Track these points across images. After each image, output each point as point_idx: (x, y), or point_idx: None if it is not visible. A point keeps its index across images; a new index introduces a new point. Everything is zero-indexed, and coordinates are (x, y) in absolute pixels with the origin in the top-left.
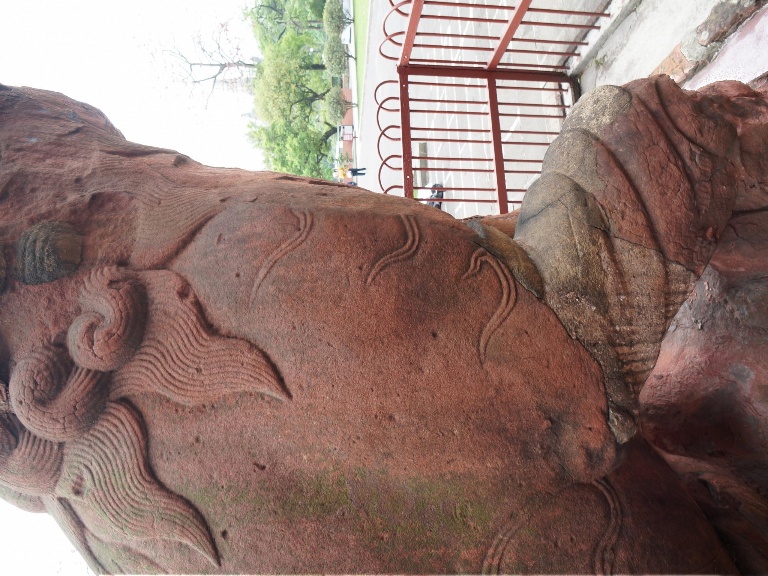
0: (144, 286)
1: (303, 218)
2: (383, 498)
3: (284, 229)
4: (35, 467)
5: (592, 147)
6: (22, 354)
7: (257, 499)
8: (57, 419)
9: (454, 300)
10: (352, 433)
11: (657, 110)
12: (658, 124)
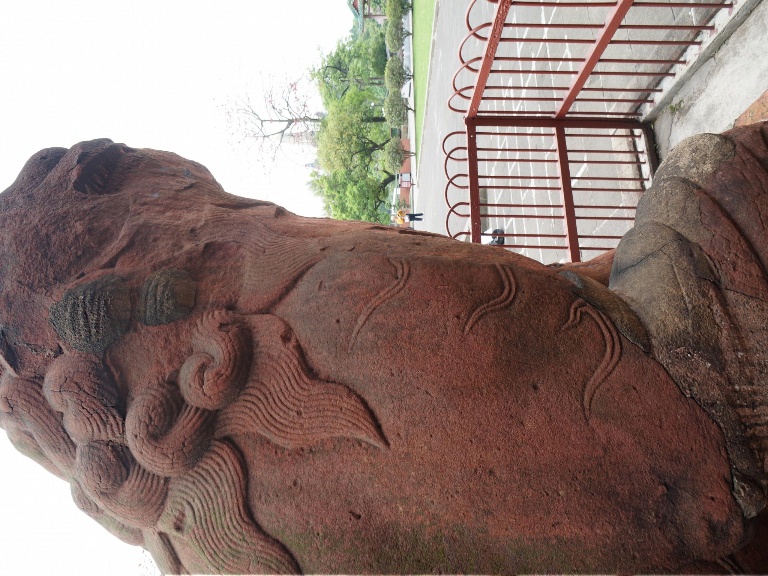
0: (250, 329)
1: (400, 267)
2: (482, 559)
3: (382, 277)
4: (142, 500)
5: (694, 196)
6: (139, 390)
7: (352, 549)
8: (167, 454)
9: (554, 352)
10: (451, 486)
11: (765, 158)
12: (767, 172)
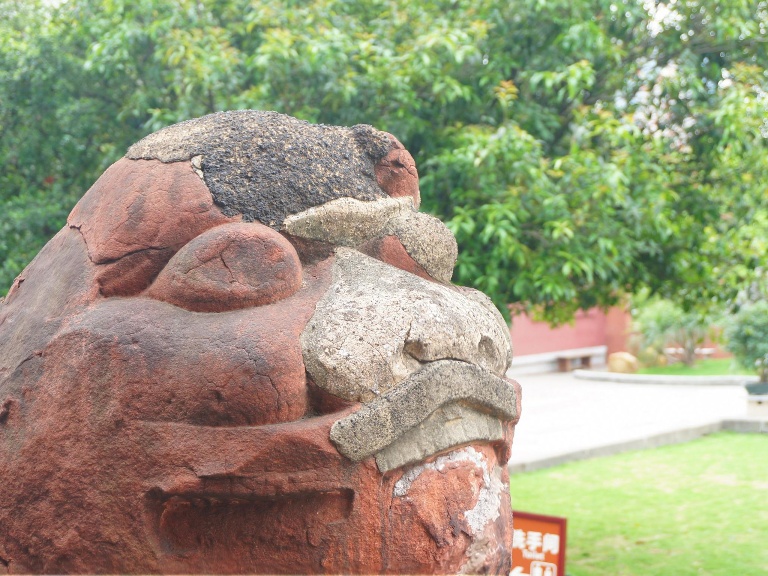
0: None
1: None
2: None
3: None
4: None
5: None
6: None
7: None
8: None
9: None
10: None
11: None
12: None
